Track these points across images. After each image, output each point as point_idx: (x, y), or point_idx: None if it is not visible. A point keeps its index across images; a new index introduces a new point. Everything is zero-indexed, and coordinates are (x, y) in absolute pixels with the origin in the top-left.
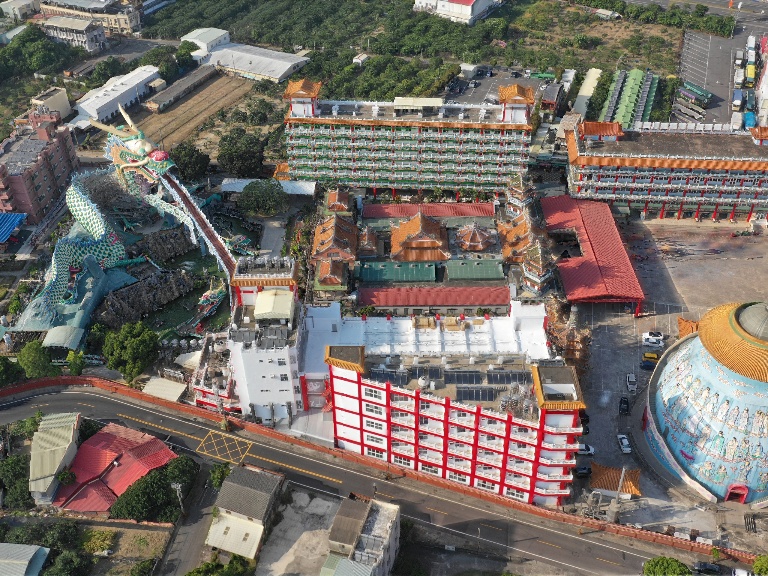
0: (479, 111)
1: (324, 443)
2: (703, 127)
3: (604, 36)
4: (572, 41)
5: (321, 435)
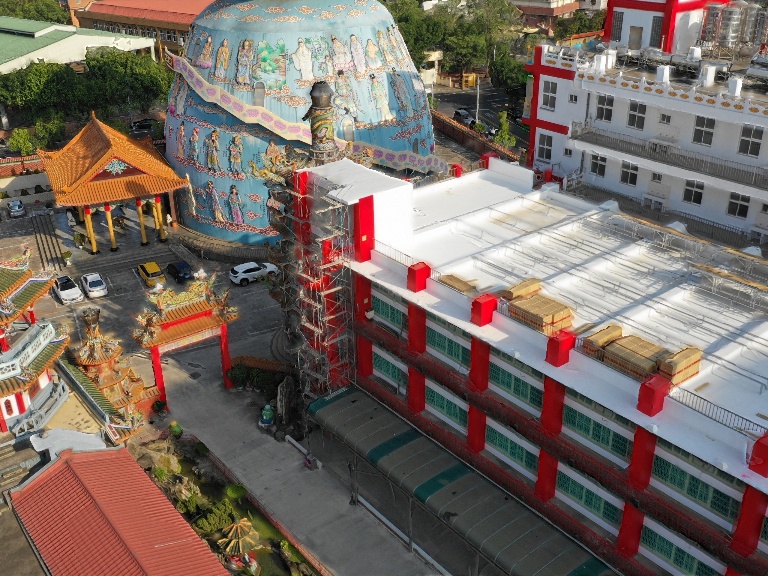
0: None
1: None
2: None
3: None
4: None
5: None
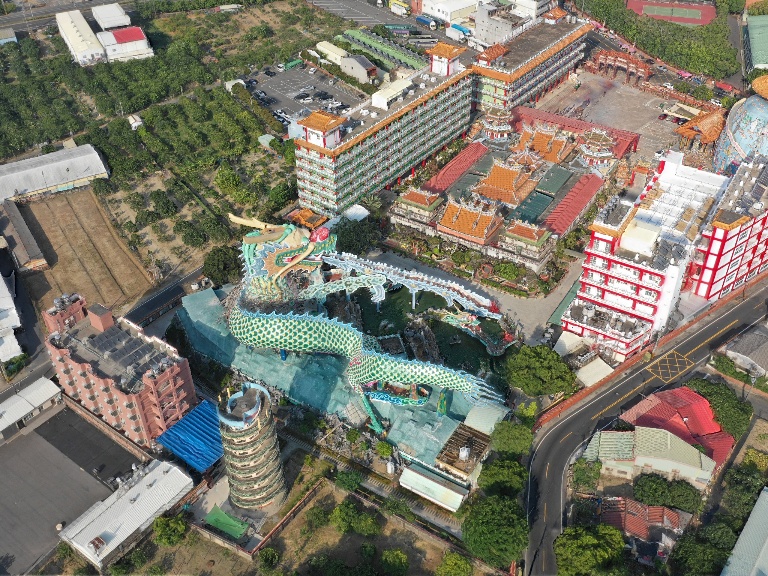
0: (421, 78)
1: (705, 309)
2: (525, 26)
3: (263, 23)
4: (256, 34)
5: (702, 305)
